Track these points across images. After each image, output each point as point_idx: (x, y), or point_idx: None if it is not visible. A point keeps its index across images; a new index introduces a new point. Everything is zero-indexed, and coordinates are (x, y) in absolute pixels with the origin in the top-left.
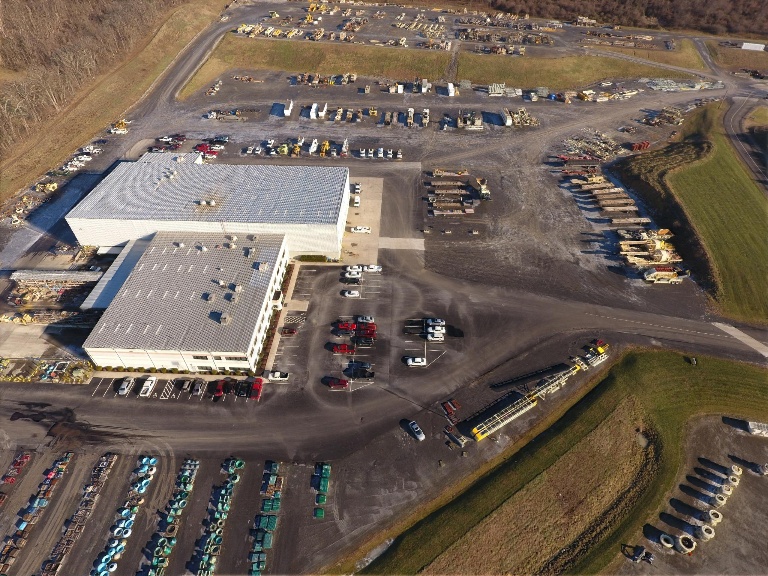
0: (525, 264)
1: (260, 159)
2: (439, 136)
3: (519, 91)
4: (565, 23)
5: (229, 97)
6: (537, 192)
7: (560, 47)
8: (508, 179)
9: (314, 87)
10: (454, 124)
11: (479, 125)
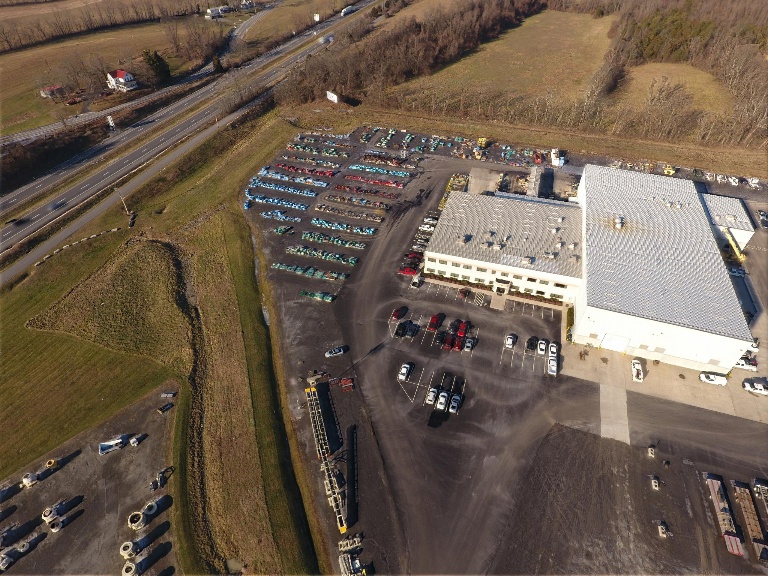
0: None
1: None
2: None
3: None
4: None
5: None
6: None
7: None
8: None
9: None
10: None
11: None
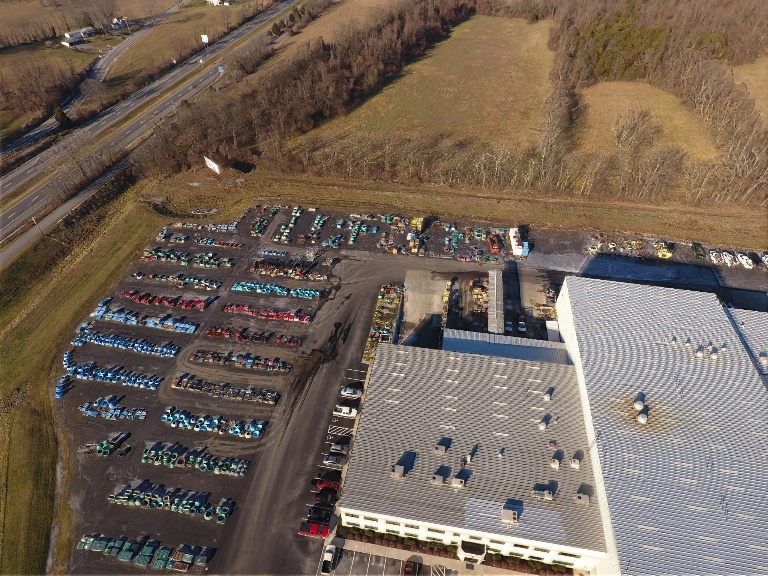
0: None
1: None
2: None
3: None
4: None
5: None
6: None
7: None
8: None
9: None
10: None
11: None
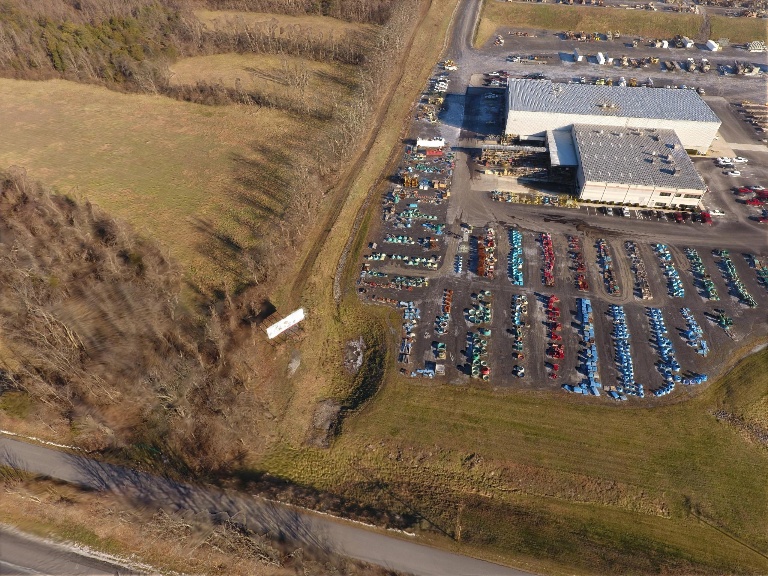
0: None
1: None
2: (724, 80)
3: None
4: None
5: (517, 47)
6: None
7: None
8: None
9: (584, 41)
10: (732, 71)
11: (756, 73)
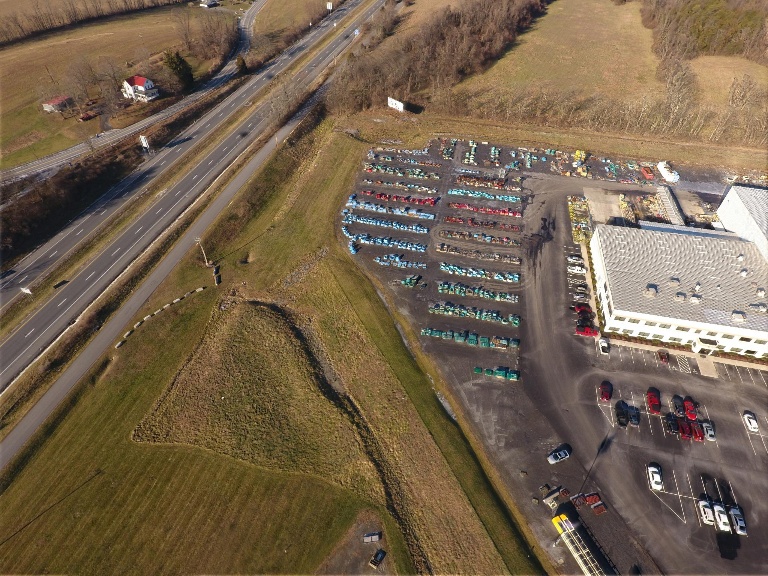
0: None
1: None
2: None
3: None
4: None
5: None
6: None
7: None
8: None
9: None
10: None
11: None
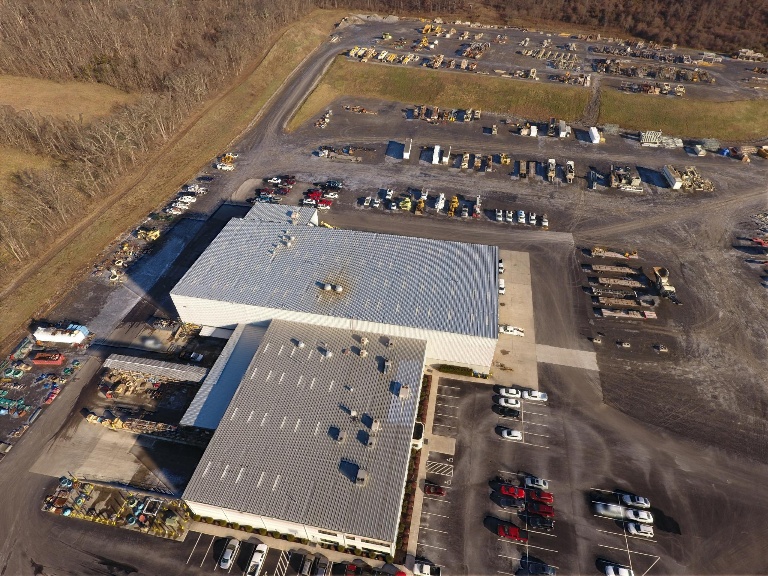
0: (745, 411)
1: (379, 214)
2: (589, 197)
3: (679, 141)
4: (722, 56)
5: (340, 131)
6: (735, 291)
7: (724, 87)
8: (690, 268)
9: (433, 123)
10: (605, 182)
11: (637, 185)
